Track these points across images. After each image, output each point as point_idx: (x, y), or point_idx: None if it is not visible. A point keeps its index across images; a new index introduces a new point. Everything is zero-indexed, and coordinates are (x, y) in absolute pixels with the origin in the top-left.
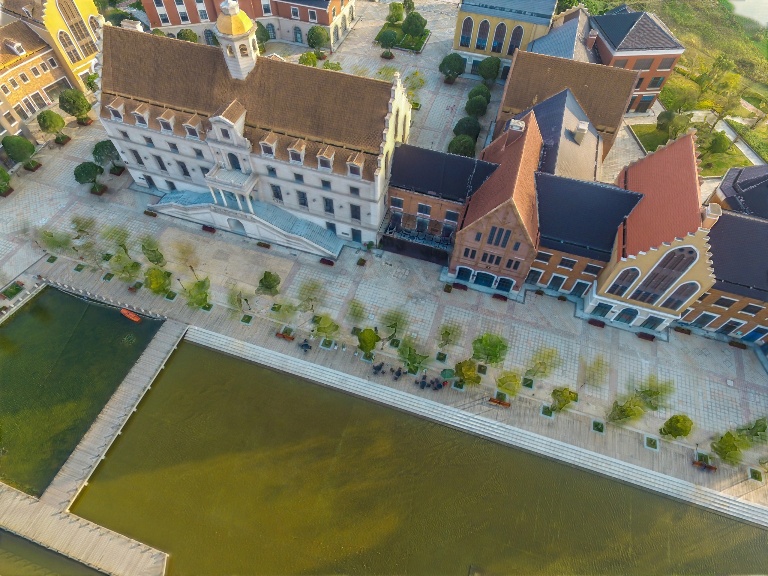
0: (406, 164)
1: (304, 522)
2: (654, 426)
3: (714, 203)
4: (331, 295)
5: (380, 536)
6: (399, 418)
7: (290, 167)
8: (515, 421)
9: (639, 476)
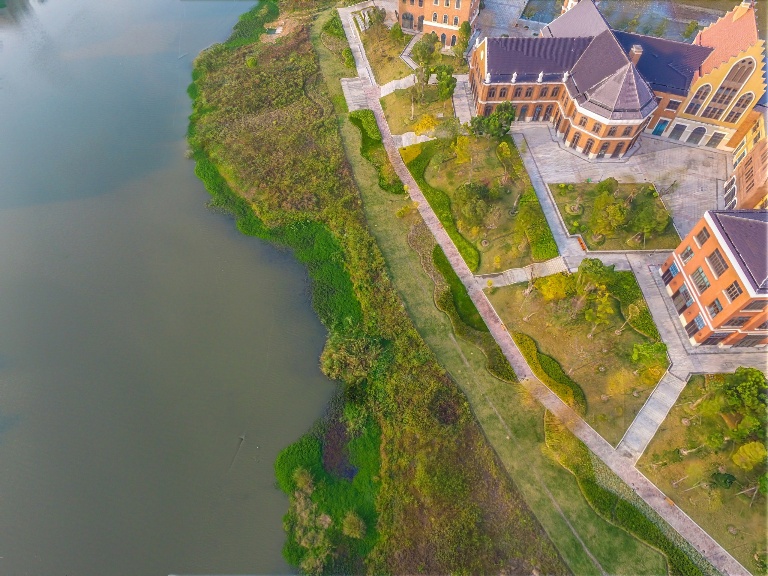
0: None
1: None
2: None
3: (749, 3)
4: None
5: None
6: None
7: None
8: None
9: None
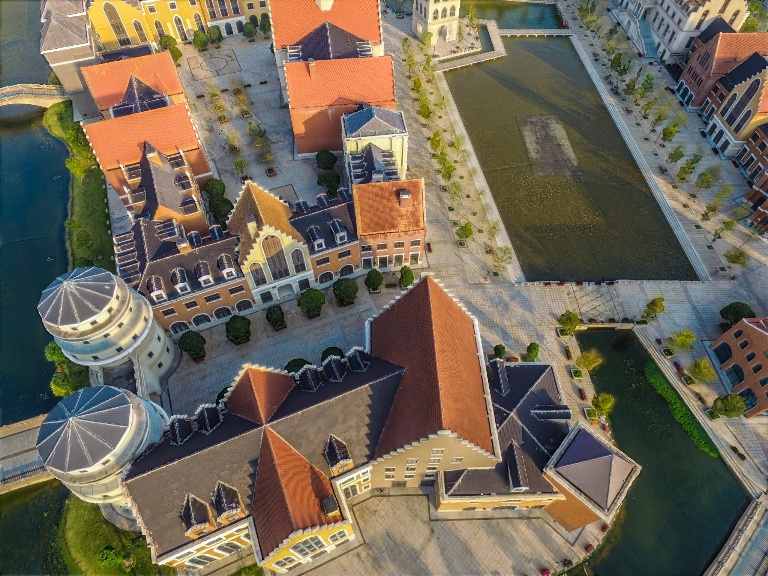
0: (713, 28)
1: (538, 78)
2: (665, 156)
3: None
4: (626, 61)
5: (549, 94)
6: (593, 90)
7: (669, 1)
8: (624, 116)
9: (636, 152)
